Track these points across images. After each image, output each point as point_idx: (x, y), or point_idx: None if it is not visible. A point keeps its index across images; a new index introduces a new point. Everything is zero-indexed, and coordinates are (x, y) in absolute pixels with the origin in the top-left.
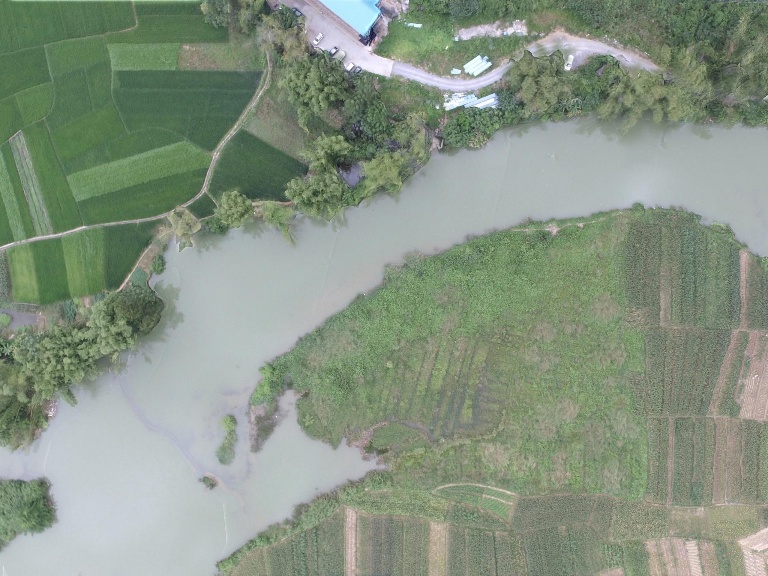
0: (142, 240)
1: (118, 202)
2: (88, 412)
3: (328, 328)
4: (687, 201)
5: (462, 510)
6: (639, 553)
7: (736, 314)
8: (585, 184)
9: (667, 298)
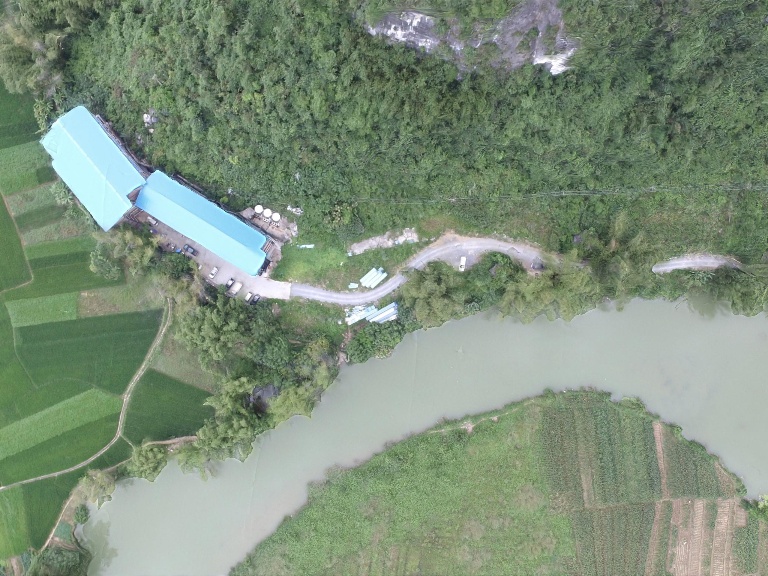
0: (62, 493)
1: (34, 458)
2: None
3: (259, 555)
4: (596, 379)
5: None
6: None
7: (657, 487)
8: (495, 375)
9: (588, 479)
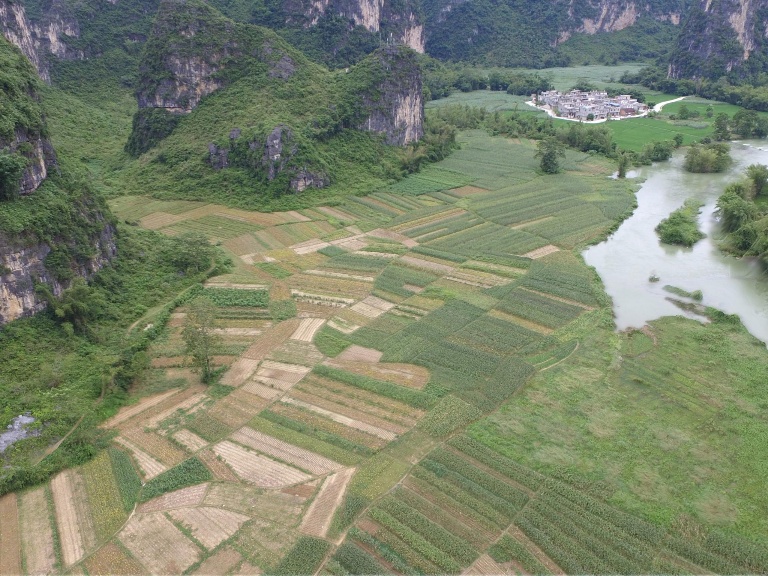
0: None
1: None
2: (732, 270)
3: (765, 351)
4: None
5: (552, 342)
6: (424, 400)
7: None
8: None
9: (708, 575)
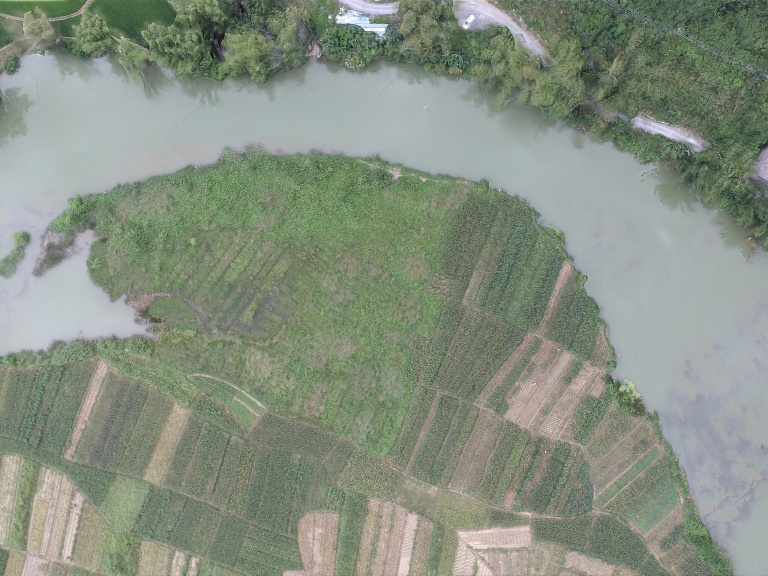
0: (4, 35)
1: None
2: None
3: (148, 185)
4: (534, 196)
5: (208, 403)
6: (359, 506)
7: (536, 318)
8: (444, 144)
9: (478, 279)
